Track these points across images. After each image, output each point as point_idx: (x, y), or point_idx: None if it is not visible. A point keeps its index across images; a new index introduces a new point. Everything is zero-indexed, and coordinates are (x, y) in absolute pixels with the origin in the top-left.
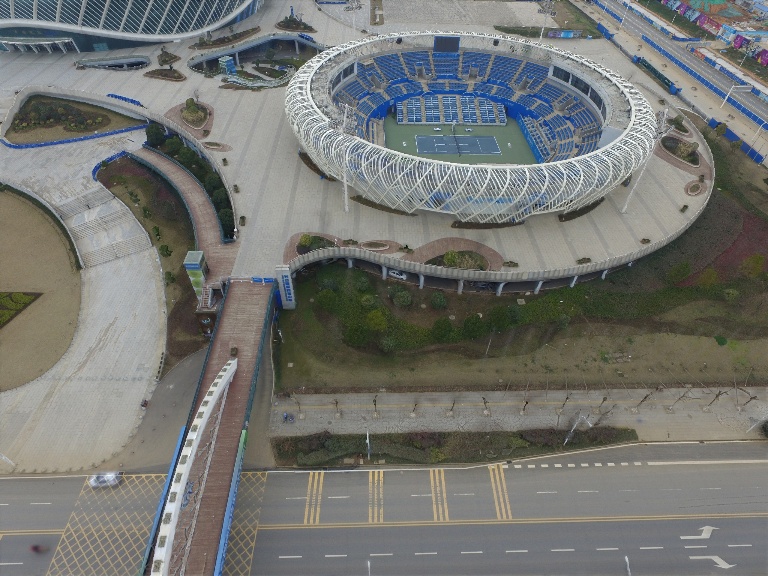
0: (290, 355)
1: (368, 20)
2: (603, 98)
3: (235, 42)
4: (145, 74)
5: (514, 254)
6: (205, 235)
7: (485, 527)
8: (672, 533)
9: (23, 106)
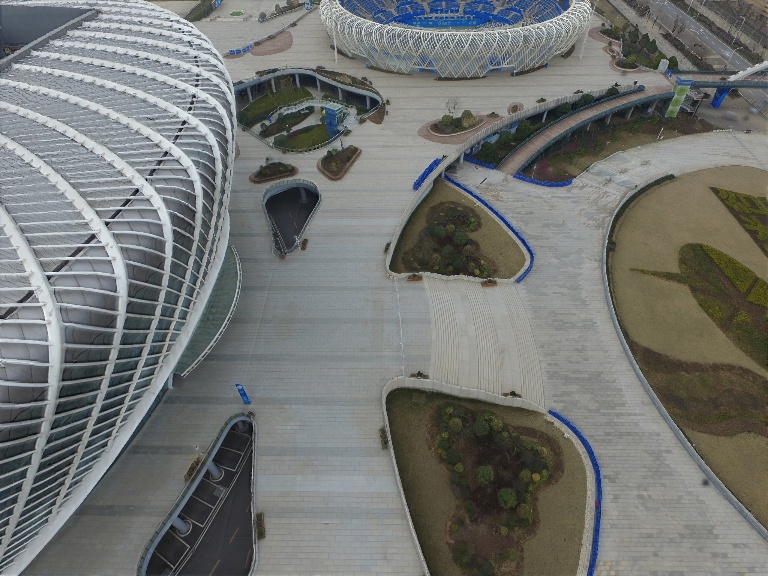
0: None
1: None
2: None
3: None
4: (339, 176)
5: None
6: None
7: (726, 59)
8: (698, 34)
9: None
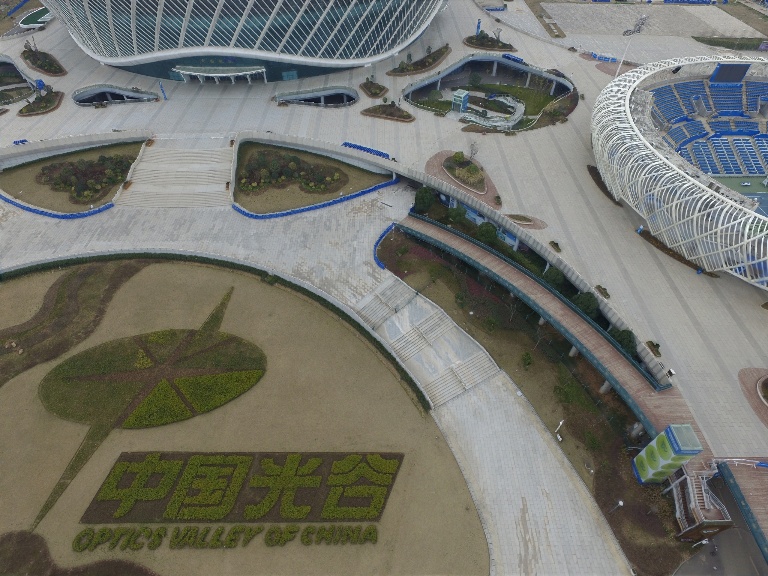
0: None
1: (544, 31)
2: None
3: (435, 66)
4: (364, 112)
5: None
6: (616, 373)
7: None
8: None
9: (238, 157)
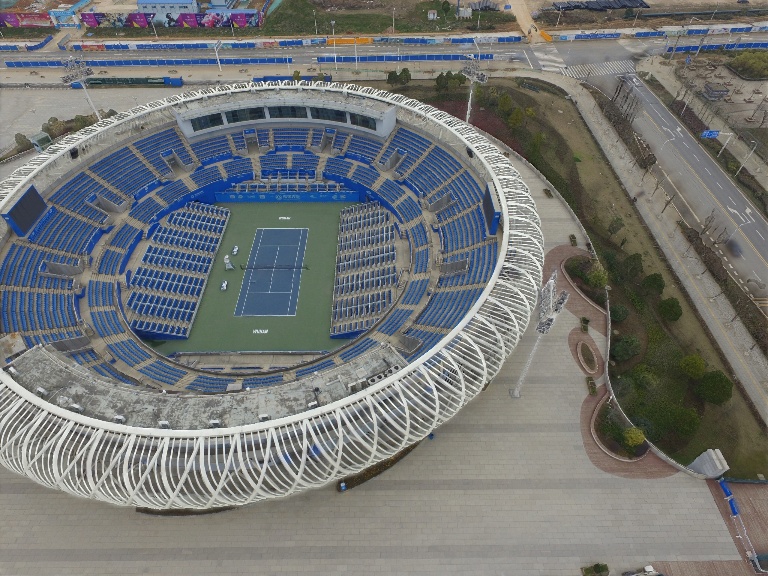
0: (751, 478)
1: None
2: (306, 104)
3: None
4: None
5: (553, 236)
6: None
7: None
8: None
9: None
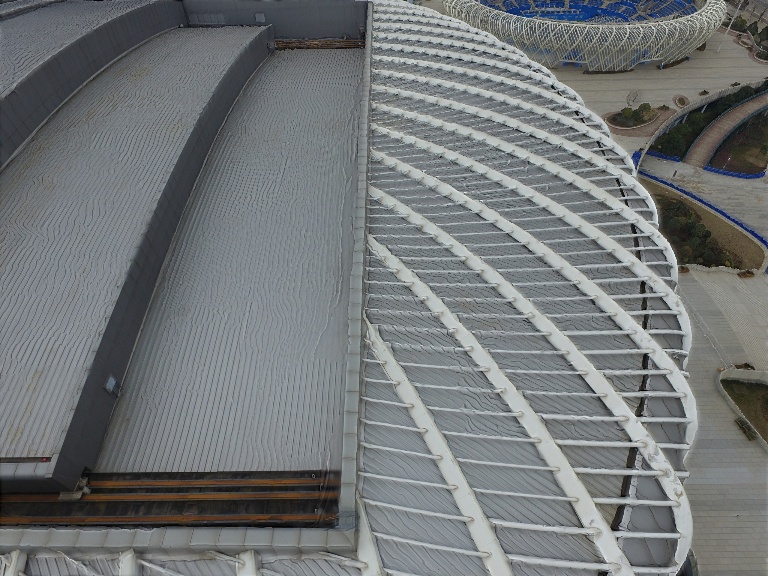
0: None
1: None
2: None
3: None
4: None
5: None
6: None
7: None
8: None
9: None
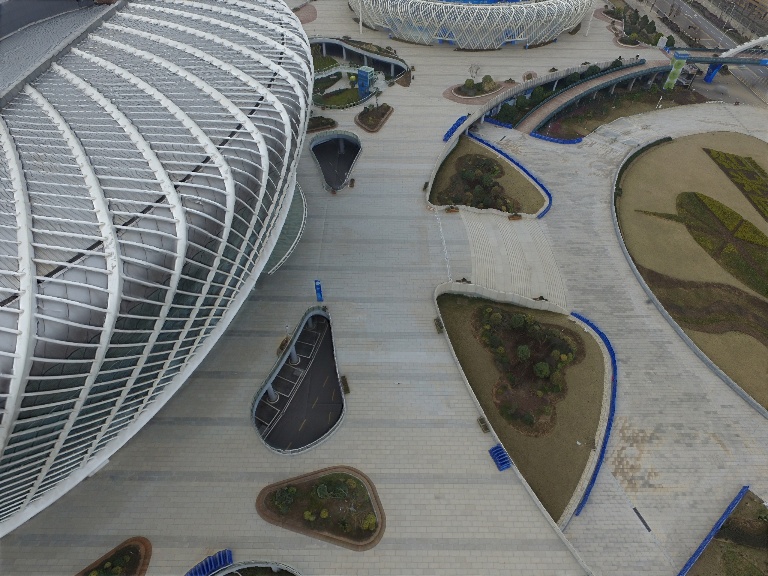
0: None
1: None
2: None
3: None
4: (376, 129)
5: (597, 6)
6: None
7: None
8: None
9: None
